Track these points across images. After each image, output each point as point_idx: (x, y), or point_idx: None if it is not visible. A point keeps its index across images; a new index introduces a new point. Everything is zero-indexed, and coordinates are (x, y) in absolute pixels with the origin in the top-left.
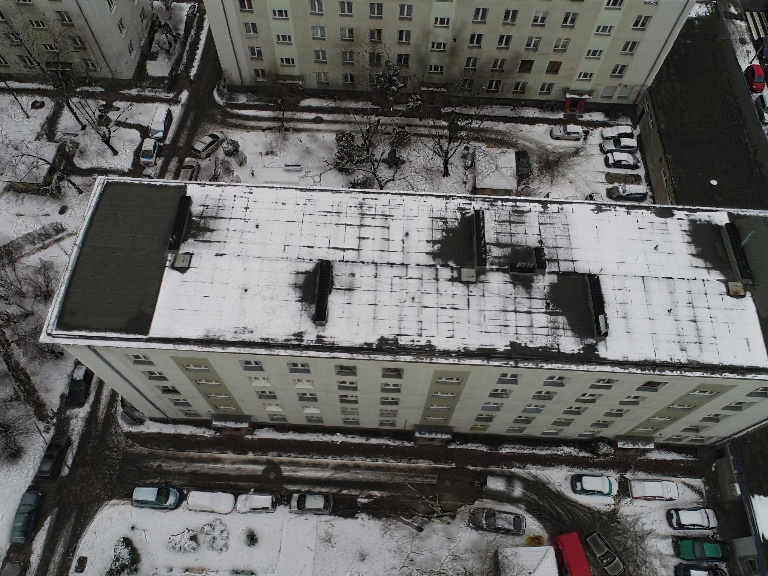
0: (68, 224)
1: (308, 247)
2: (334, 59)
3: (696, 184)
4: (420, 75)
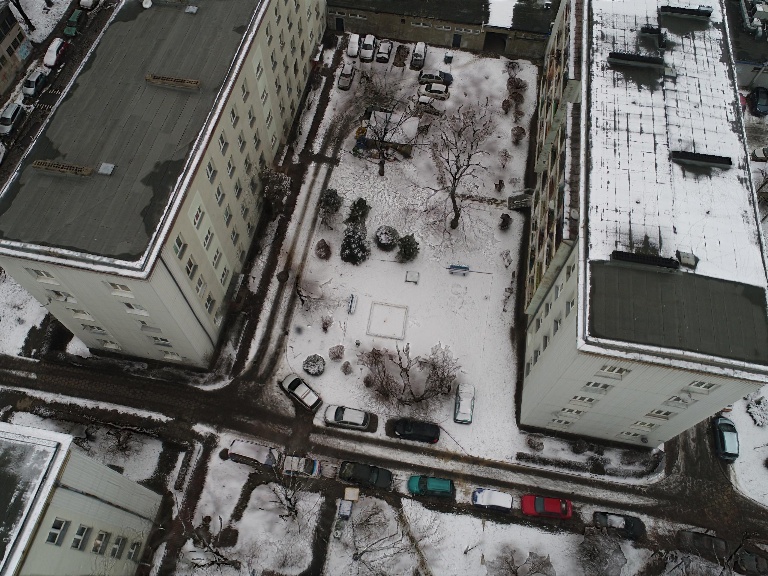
0: (406, 569)
1: (656, 167)
2: (240, 224)
3: (436, 6)
4: (270, 158)
